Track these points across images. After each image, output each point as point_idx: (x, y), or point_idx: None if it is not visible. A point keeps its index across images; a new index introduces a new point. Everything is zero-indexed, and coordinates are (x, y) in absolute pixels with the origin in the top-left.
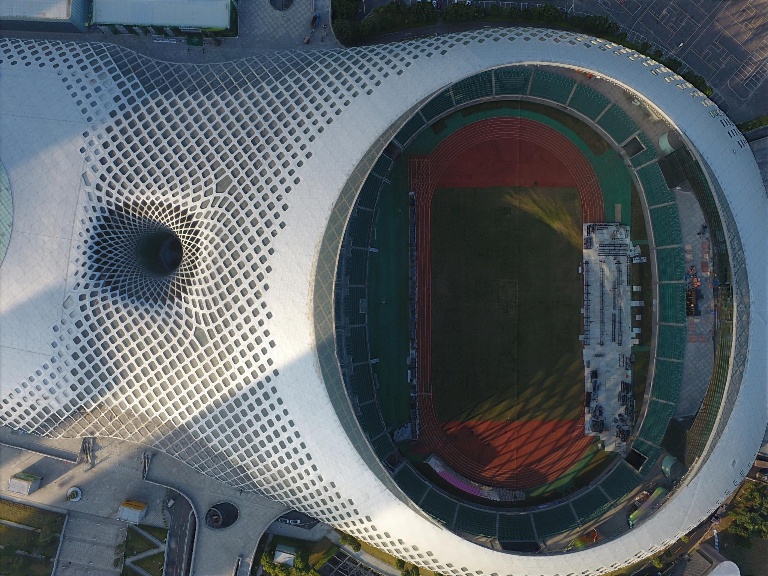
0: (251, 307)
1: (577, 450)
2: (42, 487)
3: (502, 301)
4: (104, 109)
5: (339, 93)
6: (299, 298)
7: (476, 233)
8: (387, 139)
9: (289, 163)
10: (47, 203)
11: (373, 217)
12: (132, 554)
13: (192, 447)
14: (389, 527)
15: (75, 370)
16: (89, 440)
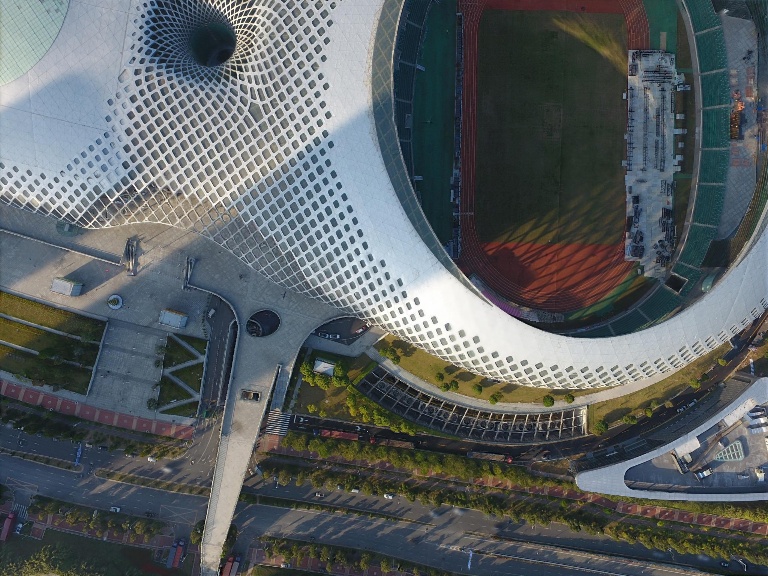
0: (308, 79)
1: (617, 275)
2: (83, 294)
3: (546, 124)
4: None
5: None
6: (357, 66)
7: (522, 56)
8: None
9: None
10: None
11: (421, 35)
12: (171, 364)
13: (241, 233)
14: (437, 309)
15: (128, 146)
16: (133, 243)
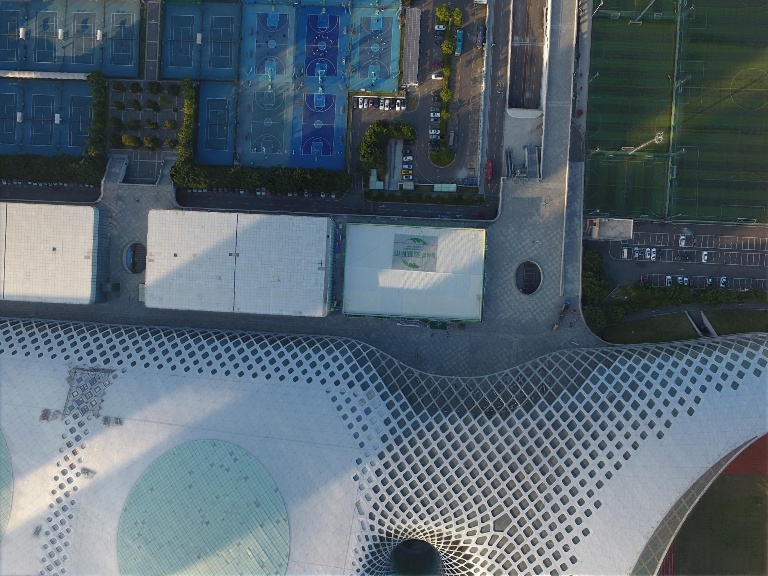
0: None
1: None
2: None
3: None
4: (375, 433)
5: (624, 431)
6: None
7: (723, 522)
8: (690, 502)
9: (575, 510)
10: (322, 532)
11: None
12: None
13: None
14: None
15: None
16: None
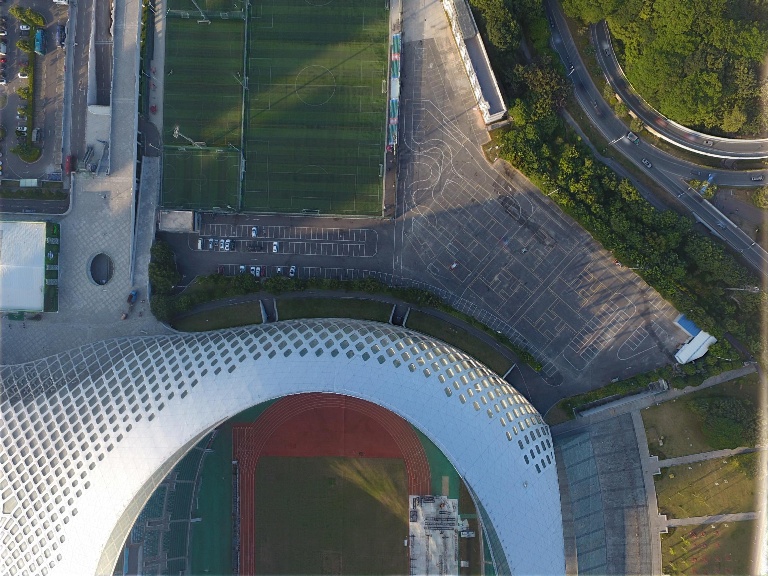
0: None
1: None
2: None
3: (326, 572)
4: None
5: (124, 414)
6: None
7: (300, 503)
8: (157, 480)
9: (69, 491)
10: None
11: (195, 487)
12: None
13: None
14: None
15: None
16: None
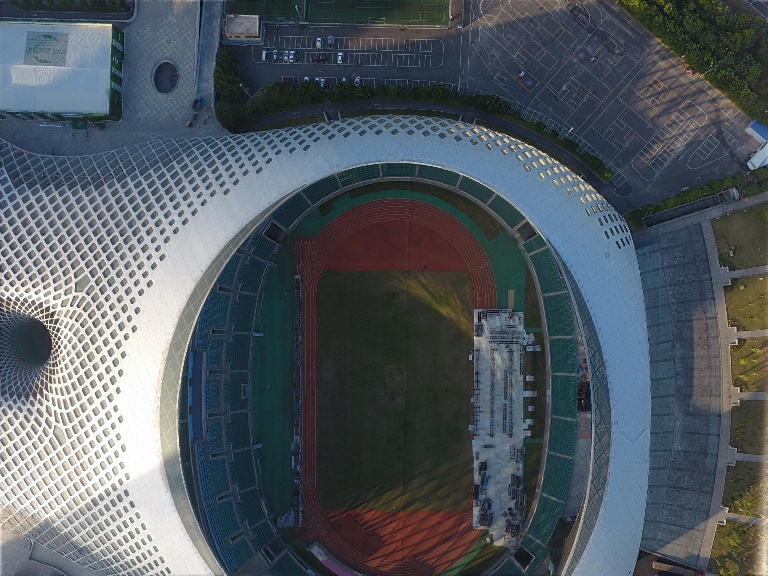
0: (104, 410)
1: (464, 543)
2: None
3: (389, 388)
4: None
5: (198, 191)
6: (147, 405)
7: (363, 318)
8: (236, 245)
9: (144, 265)
10: None
11: (257, 301)
12: None
13: (59, 539)
14: None
15: None
16: None
